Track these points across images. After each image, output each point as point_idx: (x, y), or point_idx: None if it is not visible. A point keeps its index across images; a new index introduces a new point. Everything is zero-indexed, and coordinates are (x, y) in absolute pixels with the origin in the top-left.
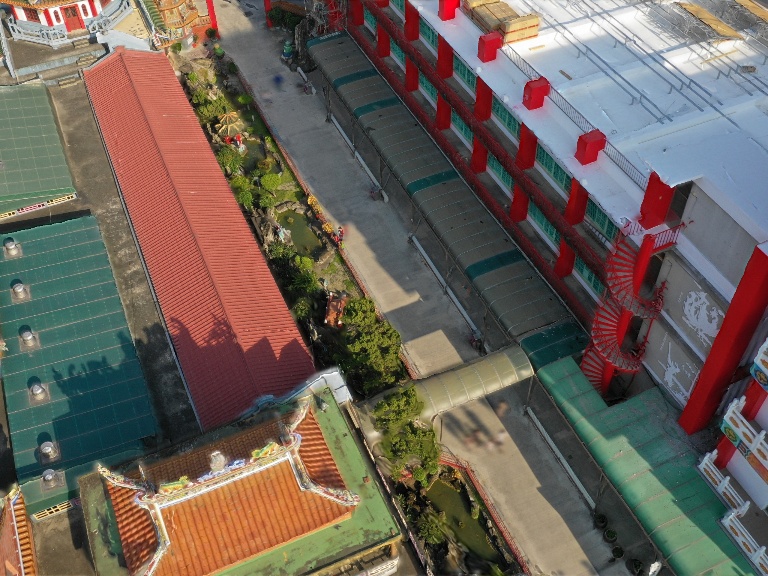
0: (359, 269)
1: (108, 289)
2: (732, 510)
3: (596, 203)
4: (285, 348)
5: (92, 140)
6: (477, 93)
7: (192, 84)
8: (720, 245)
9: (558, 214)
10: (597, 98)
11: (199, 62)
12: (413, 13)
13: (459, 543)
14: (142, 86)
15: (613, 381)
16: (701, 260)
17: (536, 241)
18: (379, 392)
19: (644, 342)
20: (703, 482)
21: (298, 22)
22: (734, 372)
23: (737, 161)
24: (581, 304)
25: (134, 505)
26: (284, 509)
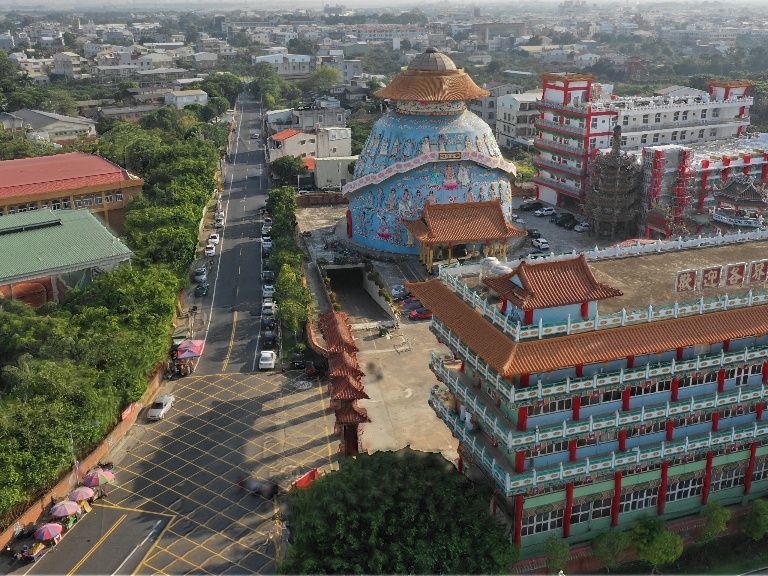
0: None
1: None
2: None
3: None
4: None
5: None
6: None
7: None
8: None
9: None
10: None
11: None
12: None
13: None
14: None
15: None
16: None
17: None
18: None
19: None
20: None
21: None
22: None
23: None
24: None
25: None
26: None
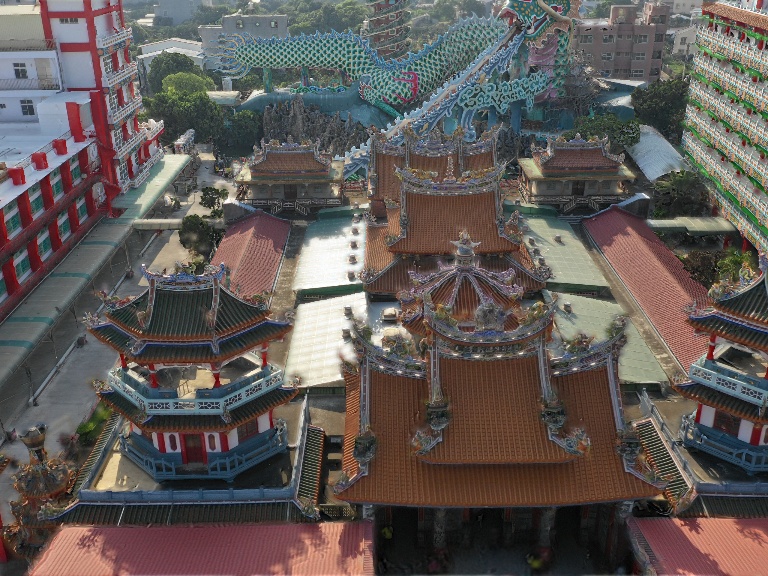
0: None
1: None
2: None
3: None
4: None
5: None
6: None
7: None
8: None
9: None
10: None
11: None
12: None
13: None
14: None
15: None
16: None
17: None
18: None
19: (94, 200)
20: None
21: None
22: None
23: None
24: None
25: None
26: None
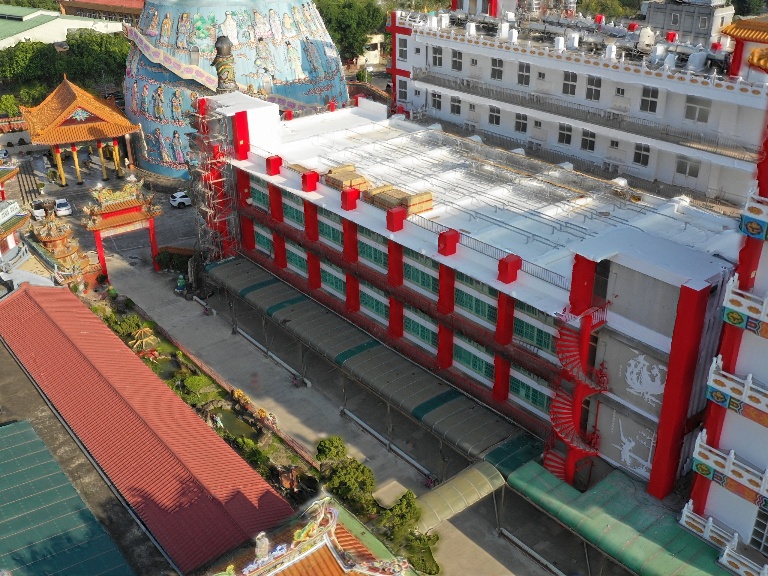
0: (301, 443)
1: (58, 479)
2: (723, 550)
3: (522, 319)
4: (261, 499)
5: (6, 364)
6: (389, 262)
7: None
8: (646, 306)
9: (490, 337)
10: (498, 242)
11: None
12: (312, 217)
13: None
14: (53, 312)
15: (575, 477)
16: (633, 327)
17: (468, 379)
18: (365, 523)
19: (594, 432)
20: (689, 534)
21: (186, 261)
22: (686, 421)
23: (638, 241)
24: (527, 416)
25: None
26: None
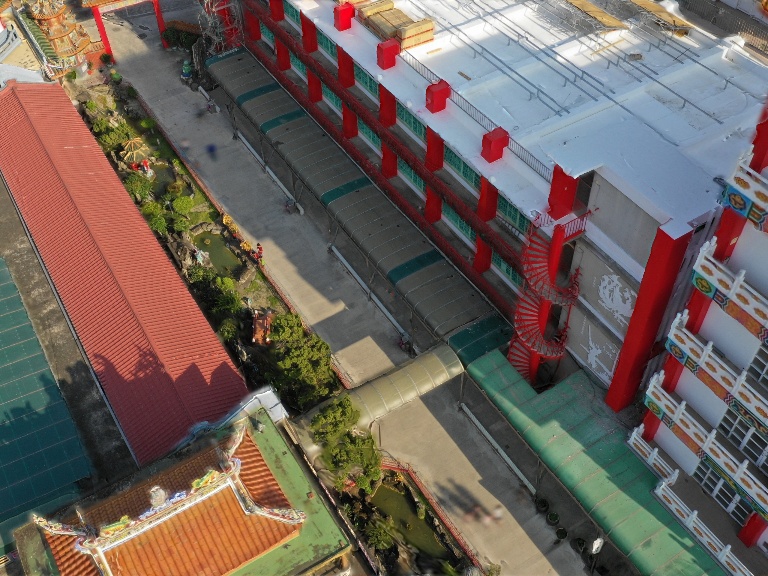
0: (282, 284)
1: (25, 332)
2: (663, 480)
3: (506, 198)
4: (215, 372)
5: None
6: (381, 100)
7: (91, 112)
8: (626, 229)
9: (471, 212)
10: (497, 96)
11: (96, 89)
12: (309, 25)
13: (408, 545)
14: (39, 119)
15: (540, 368)
16: (610, 245)
17: (453, 240)
18: (314, 405)
19: (565, 328)
20: (634, 456)
21: (194, 41)
22: (651, 348)
23: (633, 147)
24: (502, 297)
25: (75, 551)
26: (231, 536)
